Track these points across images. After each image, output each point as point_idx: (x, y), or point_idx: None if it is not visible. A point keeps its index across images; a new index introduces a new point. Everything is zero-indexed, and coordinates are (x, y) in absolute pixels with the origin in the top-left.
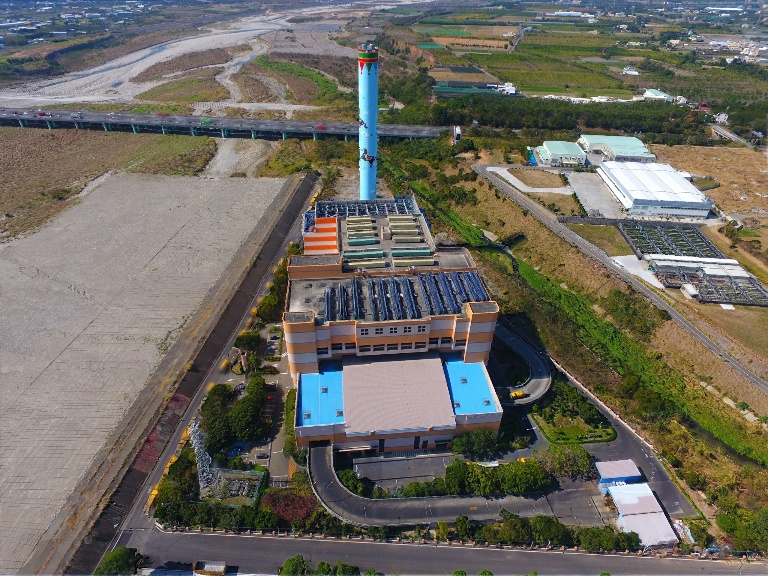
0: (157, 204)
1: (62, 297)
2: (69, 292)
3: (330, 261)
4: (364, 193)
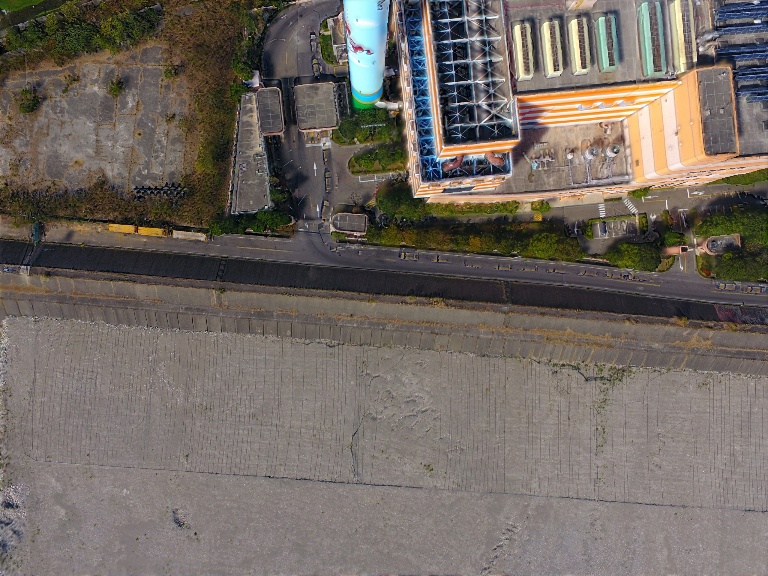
0: (169, 574)
1: (510, 575)
2: (496, 573)
3: (718, 86)
4: (384, 46)
